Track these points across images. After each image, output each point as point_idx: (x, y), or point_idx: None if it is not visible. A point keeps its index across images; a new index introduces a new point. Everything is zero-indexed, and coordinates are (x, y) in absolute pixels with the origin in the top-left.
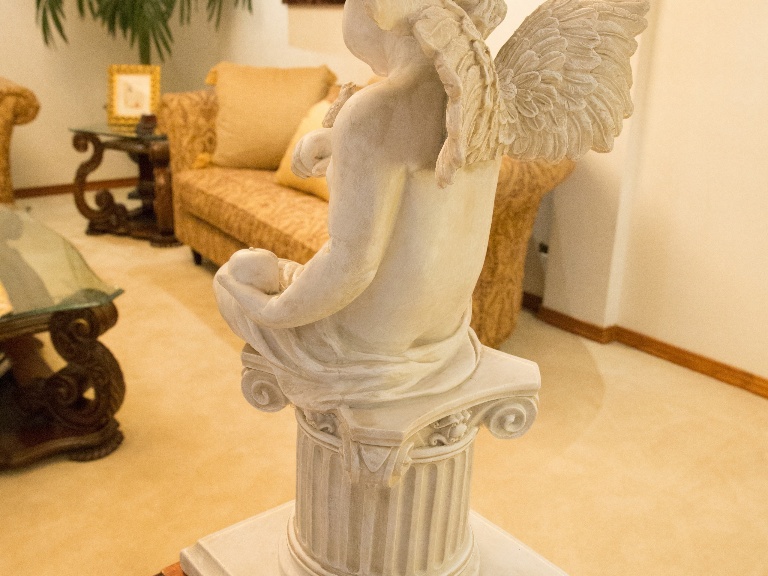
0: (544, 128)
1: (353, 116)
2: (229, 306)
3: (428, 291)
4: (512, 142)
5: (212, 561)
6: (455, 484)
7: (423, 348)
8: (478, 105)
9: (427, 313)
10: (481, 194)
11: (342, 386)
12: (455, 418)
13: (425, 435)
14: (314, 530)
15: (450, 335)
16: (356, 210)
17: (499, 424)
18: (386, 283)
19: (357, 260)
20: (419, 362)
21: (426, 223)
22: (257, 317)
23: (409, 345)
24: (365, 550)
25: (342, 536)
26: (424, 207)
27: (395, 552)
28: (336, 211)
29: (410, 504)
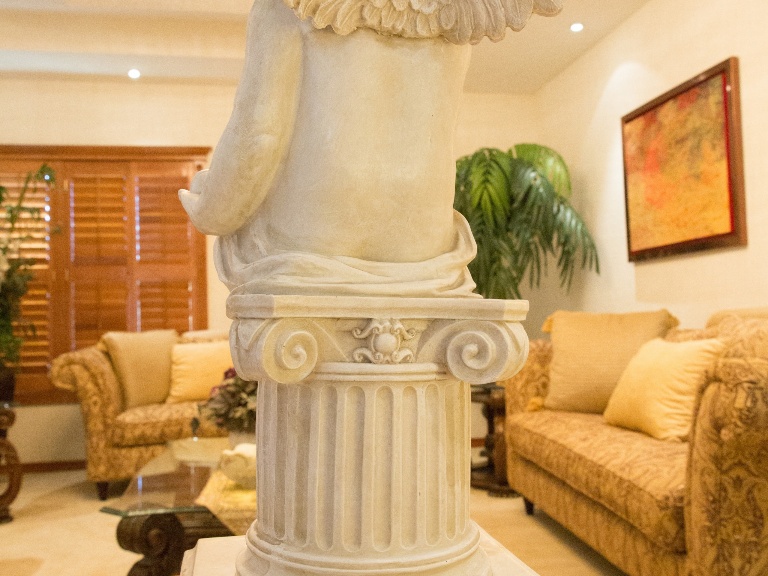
0: None
1: None
2: None
3: (339, 167)
4: (438, 15)
5: None
6: (397, 428)
7: None
8: None
9: (348, 200)
10: (412, 75)
11: None
12: (377, 323)
13: (349, 348)
14: None
15: (415, 261)
16: (249, 73)
17: (460, 359)
18: (296, 161)
19: (246, 120)
20: (351, 266)
21: (327, 88)
22: (192, 216)
23: (348, 254)
24: (288, 503)
25: (270, 486)
26: (323, 71)
27: (319, 508)
28: None
29: (334, 440)
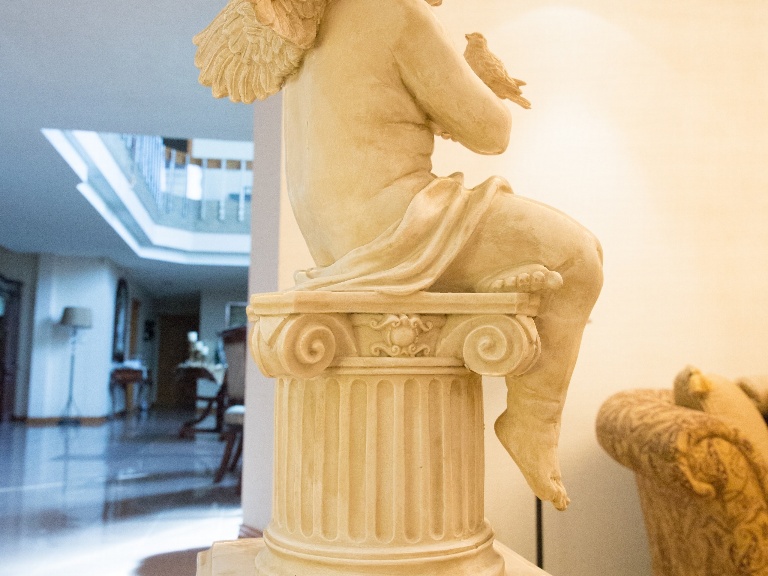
0: None
1: None
2: None
3: None
4: None
5: None
6: (276, 414)
7: (322, 267)
8: None
9: None
10: None
11: None
12: None
13: None
14: None
15: None
16: None
17: None
18: None
19: None
20: (308, 275)
21: None
22: None
23: (325, 264)
24: None
25: None
26: None
27: None
28: None
29: None
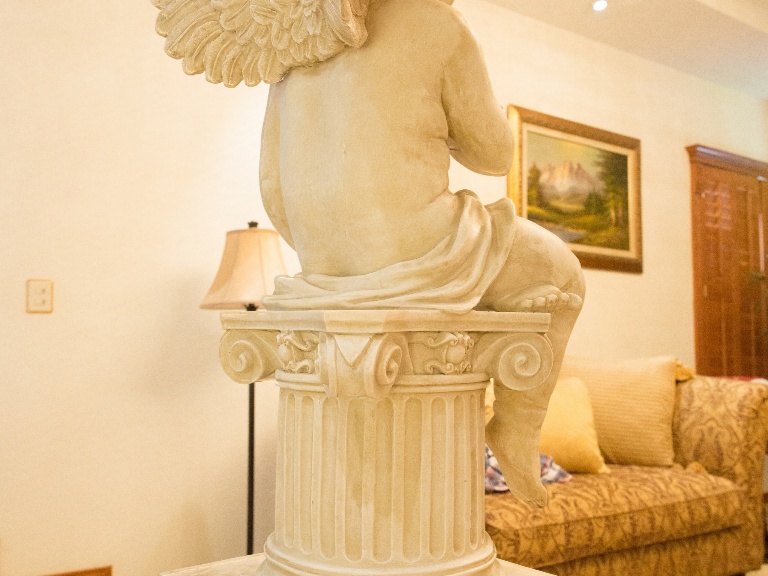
0: None
1: None
2: None
3: (286, 197)
4: None
5: None
6: (297, 434)
7: (330, 276)
8: (212, 8)
9: (299, 224)
10: (329, 95)
11: None
12: (280, 334)
13: None
14: None
15: (367, 273)
16: None
17: None
18: None
19: None
20: (310, 283)
21: None
22: None
23: (325, 272)
24: None
25: None
26: None
27: None
28: None
29: None
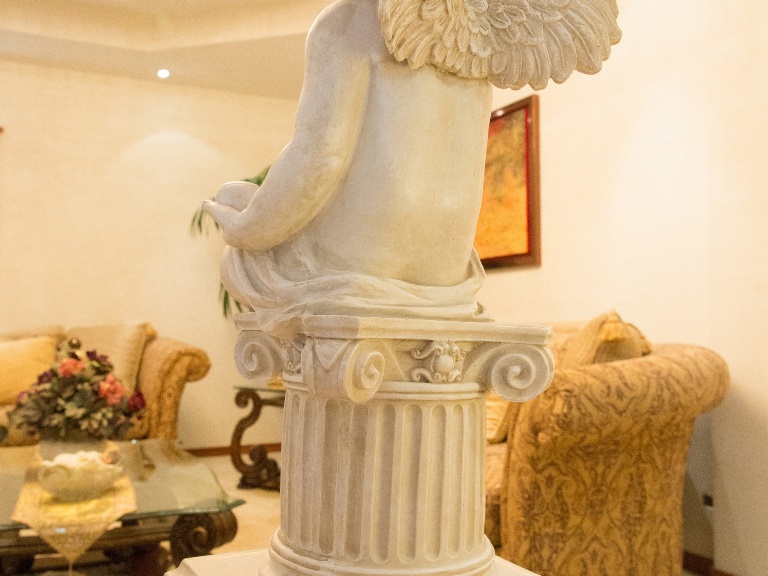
0: (520, 40)
1: (320, 17)
2: (224, 261)
3: (401, 194)
4: (490, 59)
5: (190, 573)
6: (448, 444)
7: None
8: None
9: (405, 226)
10: (462, 112)
11: (310, 298)
12: (438, 345)
13: (406, 368)
14: (290, 508)
15: (448, 285)
16: (318, 94)
17: (503, 379)
18: (356, 185)
19: (317, 141)
20: (401, 289)
21: (394, 117)
22: (231, 229)
23: (394, 277)
24: (339, 519)
25: (315, 502)
26: (391, 101)
27: (374, 523)
28: (301, 102)
29: (390, 456)
